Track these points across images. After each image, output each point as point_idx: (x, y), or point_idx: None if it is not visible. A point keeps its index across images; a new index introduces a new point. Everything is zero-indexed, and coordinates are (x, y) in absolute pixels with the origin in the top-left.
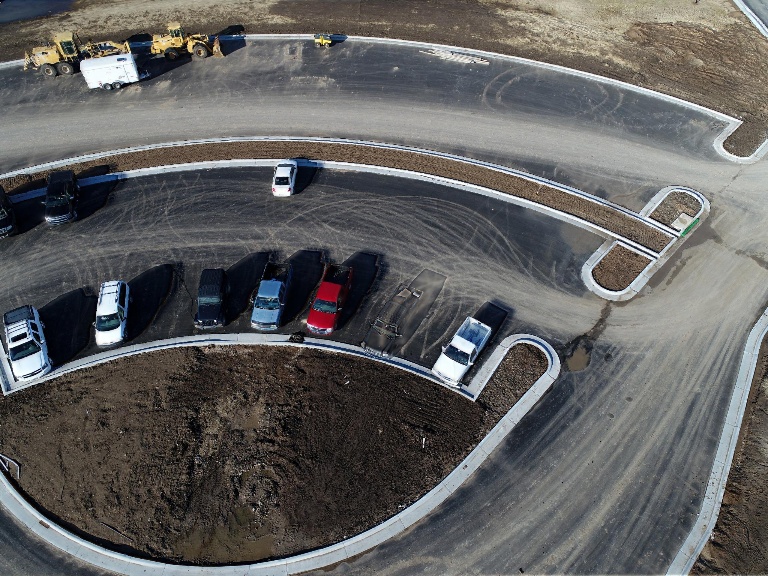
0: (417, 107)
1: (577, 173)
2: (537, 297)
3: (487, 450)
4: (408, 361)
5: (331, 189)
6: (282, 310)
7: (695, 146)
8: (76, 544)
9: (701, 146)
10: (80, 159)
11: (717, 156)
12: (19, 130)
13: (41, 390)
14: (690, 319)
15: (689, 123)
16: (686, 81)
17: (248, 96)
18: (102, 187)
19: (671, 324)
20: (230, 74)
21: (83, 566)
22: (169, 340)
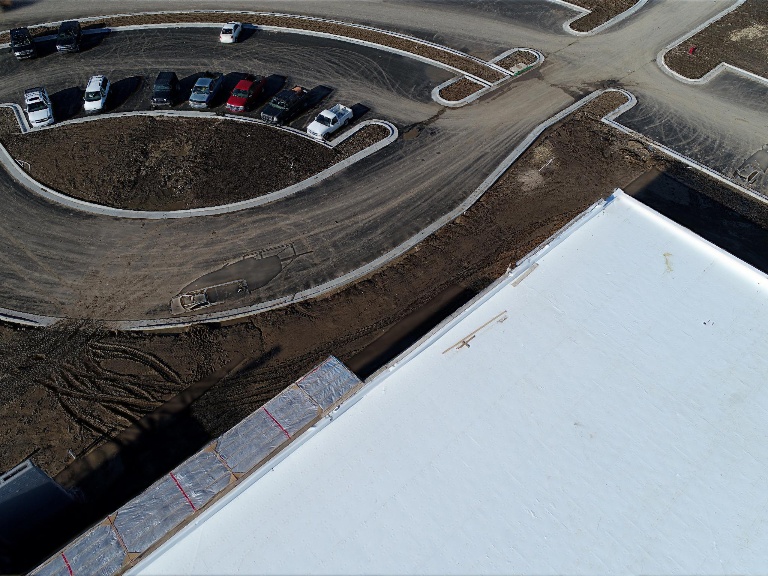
0: None
1: (451, 38)
2: (395, 102)
3: (333, 171)
4: (293, 128)
5: (264, 41)
6: (212, 97)
7: (548, 25)
8: (62, 199)
9: (553, 25)
10: (85, 19)
11: (563, 31)
12: (42, 2)
13: (47, 132)
14: (500, 117)
15: (550, 12)
16: None
17: None
18: (99, 35)
19: (485, 119)
20: None
21: (66, 208)
22: (134, 112)
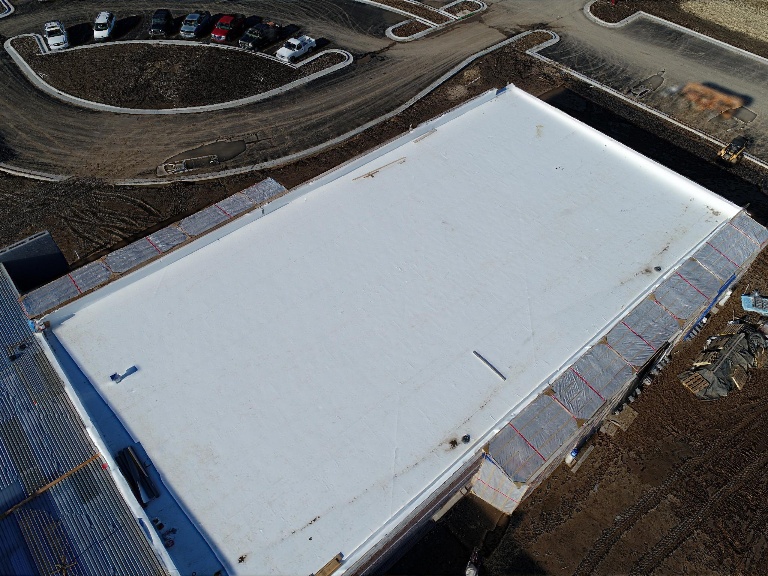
0: None
1: None
2: (353, 37)
3: (295, 85)
4: (265, 54)
5: None
6: (199, 30)
7: None
8: (74, 100)
9: None
10: None
11: None
12: None
13: (62, 54)
14: (440, 49)
15: None
16: None
17: None
18: None
19: (428, 50)
20: None
21: (77, 106)
22: (134, 41)
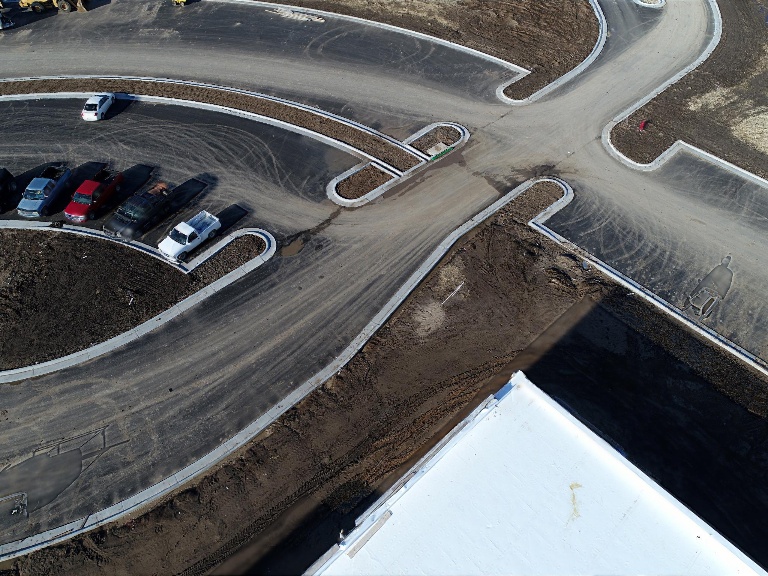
0: (243, 55)
1: (362, 110)
2: (280, 202)
3: (182, 309)
4: (144, 244)
5: (138, 117)
6: (49, 202)
7: (479, 91)
8: None
9: (485, 91)
10: None
11: (495, 99)
12: None
13: None
14: (405, 221)
15: (483, 72)
16: (496, 38)
17: (96, 43)
18: None
19: (386, 225)
20: (87, 25)
21: None
22: None
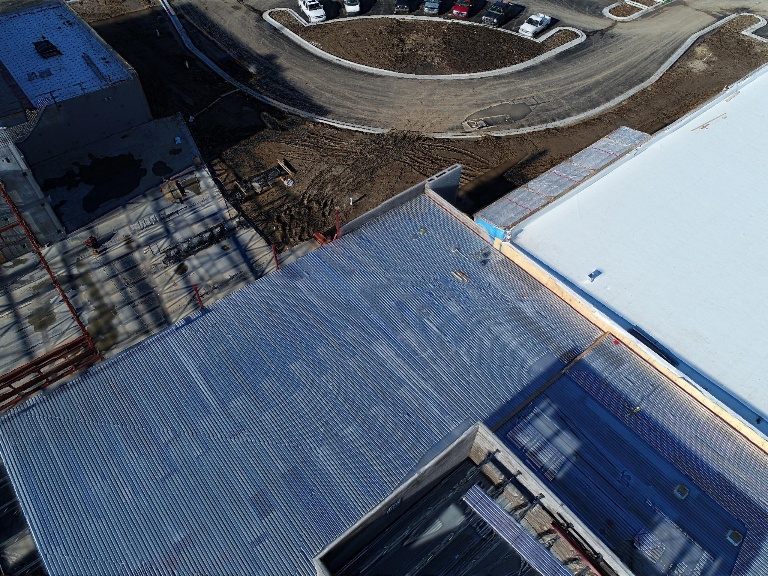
0: None
1: None
2: (576, 17)
3: (546, 57)
4: (506, 29)
5: None
6: (439, 6)
7: None
8: (355, 65)
9: None
10: None
11: None
12: None
13: (322, 26)
14: (661, 29)
15: None
16: None
17: None
18: None
19: (650, 29)
20: None
21: (360, 71)
22: (381, 15)
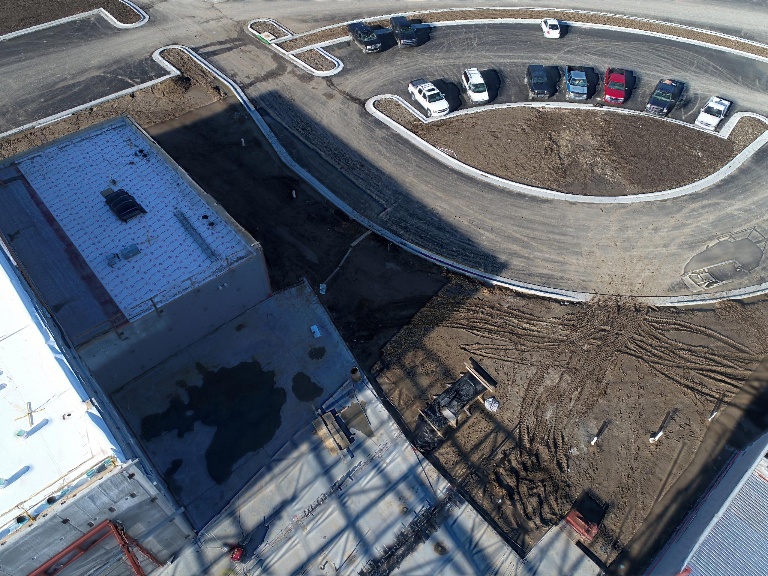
0: None
1: (759, 35)
2: (750, 96)
3: (741, 160)
4: (676, 119)
5: (584, 37)
6: None
7: None
8: (508, 184)
9: None
10: (398, 15)
11: None
12: None
13: (446, 122)
14: None
15: None
16: None
17: None
18: (422, 30)
19: None
20: None
21: (517, 192)
22: (515, 103)
